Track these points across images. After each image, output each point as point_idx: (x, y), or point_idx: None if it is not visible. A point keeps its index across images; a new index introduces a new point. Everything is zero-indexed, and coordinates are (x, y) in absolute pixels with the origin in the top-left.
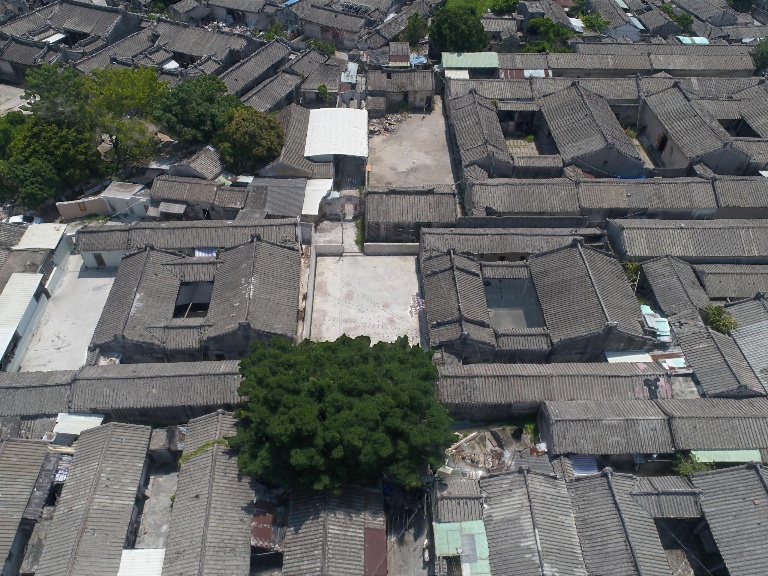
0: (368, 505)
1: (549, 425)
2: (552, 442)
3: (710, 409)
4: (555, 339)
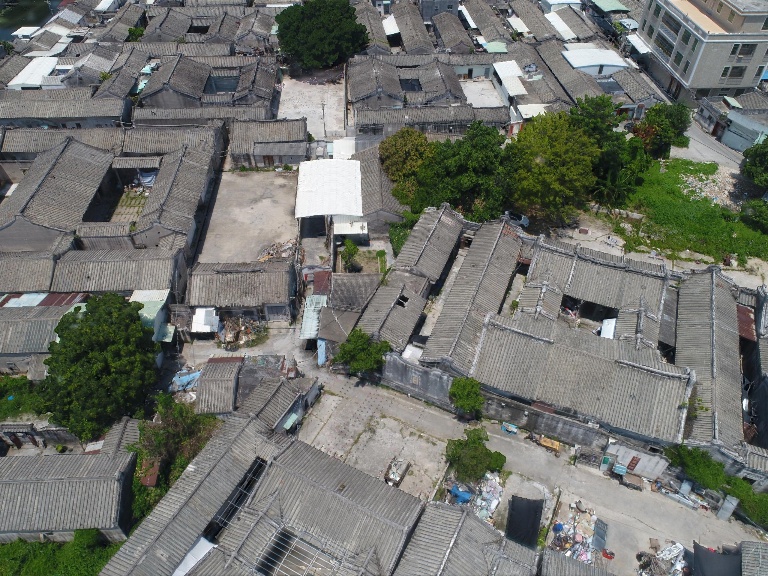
0: None
1: None
2: (233, 44)
3: (155, 47)
4: (210, 67)
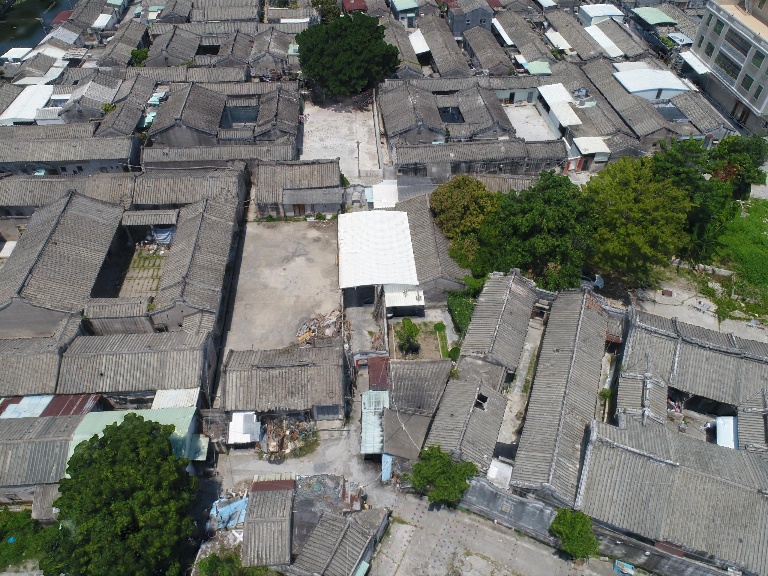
0: None
1: None
2: None
3: (162, 72)
4: (225, 95)
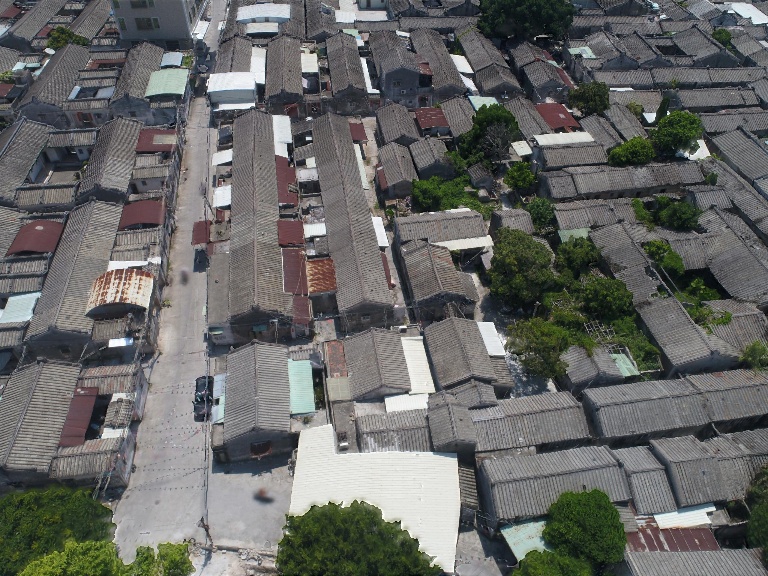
0: (540, 47)
1: (609, 26)
2: (611, 30)
3: None
4: None
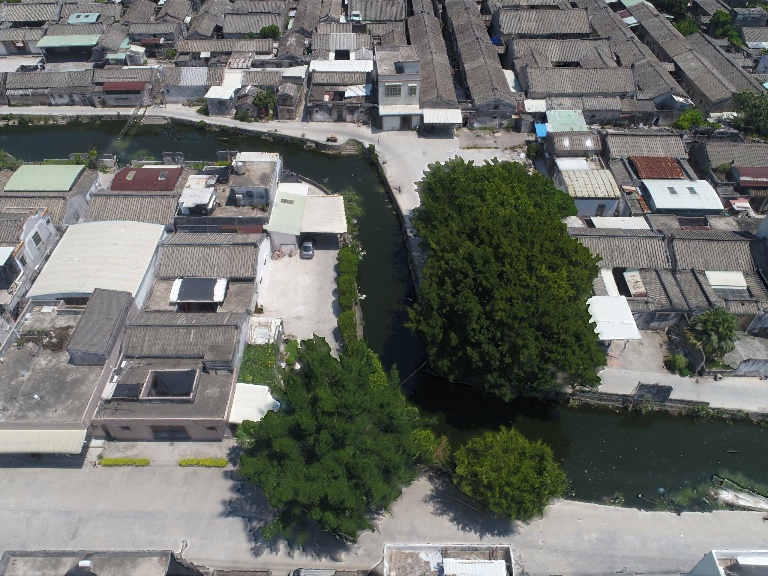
0: None
1: None
2: None
3: None
4: None
